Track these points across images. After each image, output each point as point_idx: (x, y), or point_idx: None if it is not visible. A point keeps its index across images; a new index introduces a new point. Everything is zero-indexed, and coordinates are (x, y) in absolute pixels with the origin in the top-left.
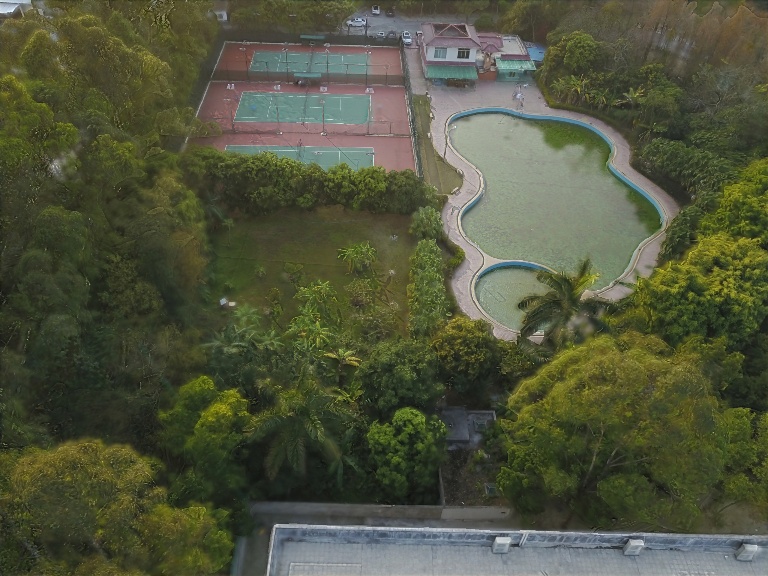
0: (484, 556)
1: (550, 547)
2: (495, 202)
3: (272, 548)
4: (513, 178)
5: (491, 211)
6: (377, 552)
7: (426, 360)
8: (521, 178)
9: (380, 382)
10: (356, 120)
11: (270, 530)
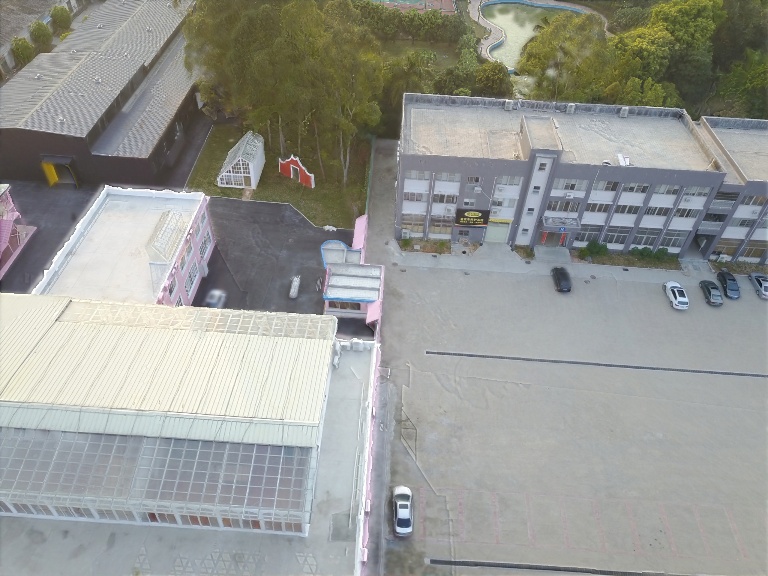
0: (500, 111)
1: (532, 111)
2: (512, 46)
3: (404, 98)
4: (525, 35)
5: (509, 49)
6: (451, 108)
7: (471, 71)
8: (530, 35)
9: (445, 83)
10: (416, 2)
11: (385, 155)
